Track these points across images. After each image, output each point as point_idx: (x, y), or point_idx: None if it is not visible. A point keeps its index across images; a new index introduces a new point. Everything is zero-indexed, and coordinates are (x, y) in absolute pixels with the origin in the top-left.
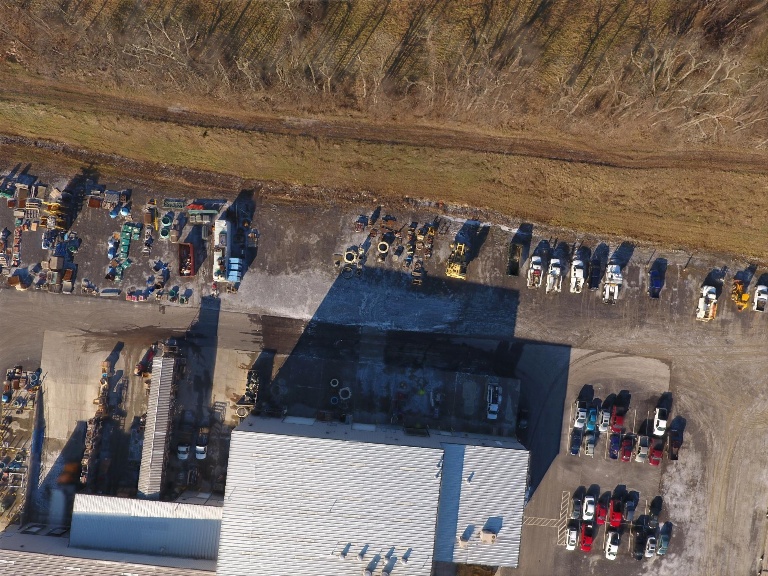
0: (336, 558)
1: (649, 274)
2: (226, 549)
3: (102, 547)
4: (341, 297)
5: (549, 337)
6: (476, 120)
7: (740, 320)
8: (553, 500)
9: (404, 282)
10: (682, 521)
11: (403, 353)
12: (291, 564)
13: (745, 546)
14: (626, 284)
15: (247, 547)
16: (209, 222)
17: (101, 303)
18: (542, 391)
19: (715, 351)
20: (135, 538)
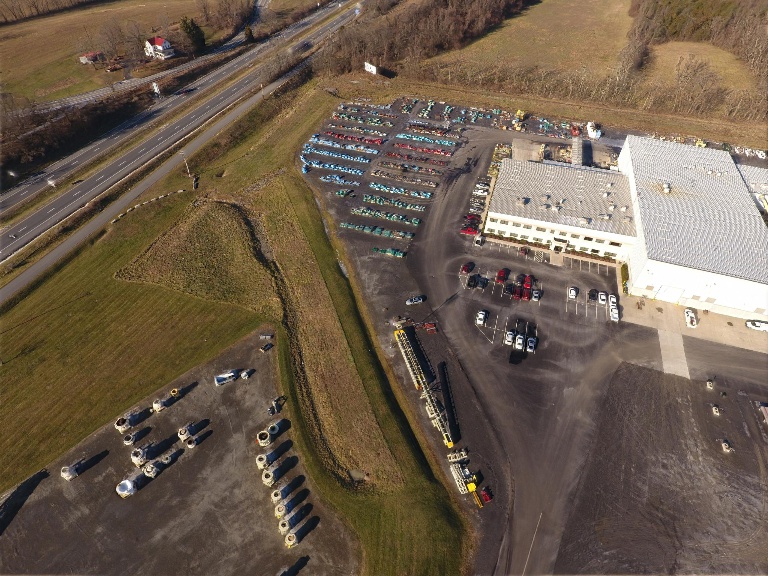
0: None
1: None
2: None
3: None
4: None
5: None
6: (692, 116)
7: None
8: None
9: None
10: None
11: None
12: None
13: None
14: None
15: None
16: (582, 126)
17: None
18: None
19: None
20: None
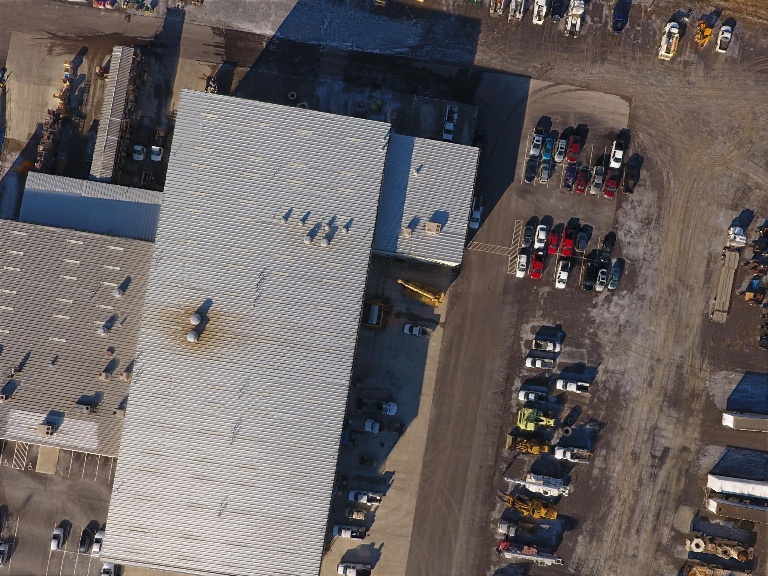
0: (277, 222)
1: (612, 10)
2: (169, 204)
3: (51, 224)
4: (304, 15)
5: (509, 67)
6: None
7: (703, 62)
8: (505, 228)
9: (367, 5)
10: (635, 258)
11: (363, 73)
12: (232, 224)
13: (698, 288)
14: (589, 20)
15: (190, 204)
16: None
17: (68, 8)
18: (499, 119)
19: (676, 91)
20: (84, 218)
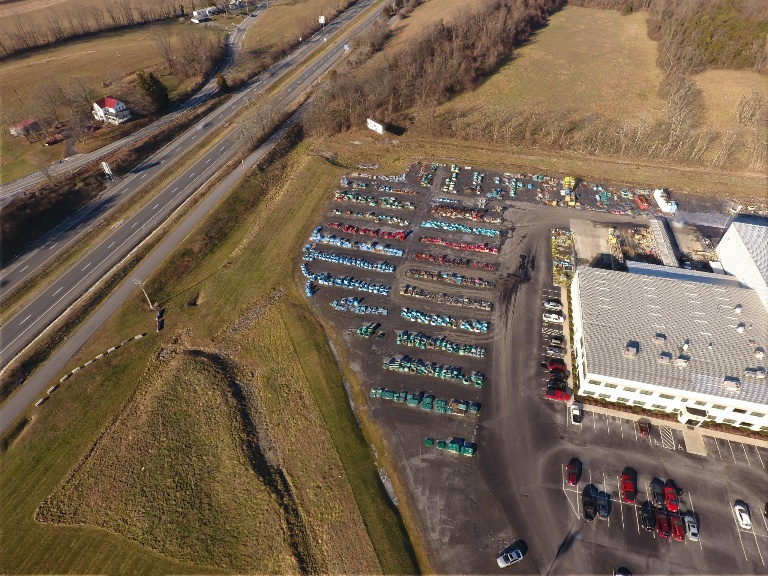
0: None
1: None
2: (760, 263)
3: None
4: None
5: None
6: None
7: None
8: None
9: None
10: None
11: None
12: None
13: None
14: None
15: None
16: (648, 194)
17: (598, 213)
18: None
19: None
20: None
